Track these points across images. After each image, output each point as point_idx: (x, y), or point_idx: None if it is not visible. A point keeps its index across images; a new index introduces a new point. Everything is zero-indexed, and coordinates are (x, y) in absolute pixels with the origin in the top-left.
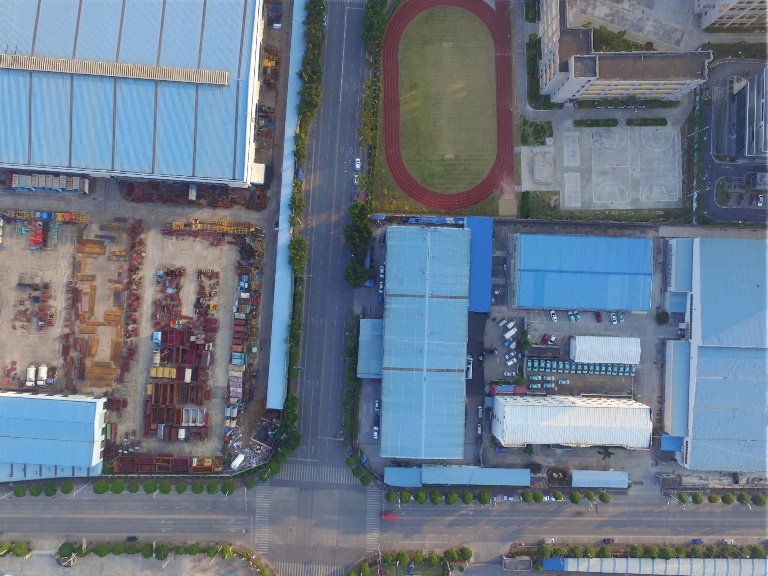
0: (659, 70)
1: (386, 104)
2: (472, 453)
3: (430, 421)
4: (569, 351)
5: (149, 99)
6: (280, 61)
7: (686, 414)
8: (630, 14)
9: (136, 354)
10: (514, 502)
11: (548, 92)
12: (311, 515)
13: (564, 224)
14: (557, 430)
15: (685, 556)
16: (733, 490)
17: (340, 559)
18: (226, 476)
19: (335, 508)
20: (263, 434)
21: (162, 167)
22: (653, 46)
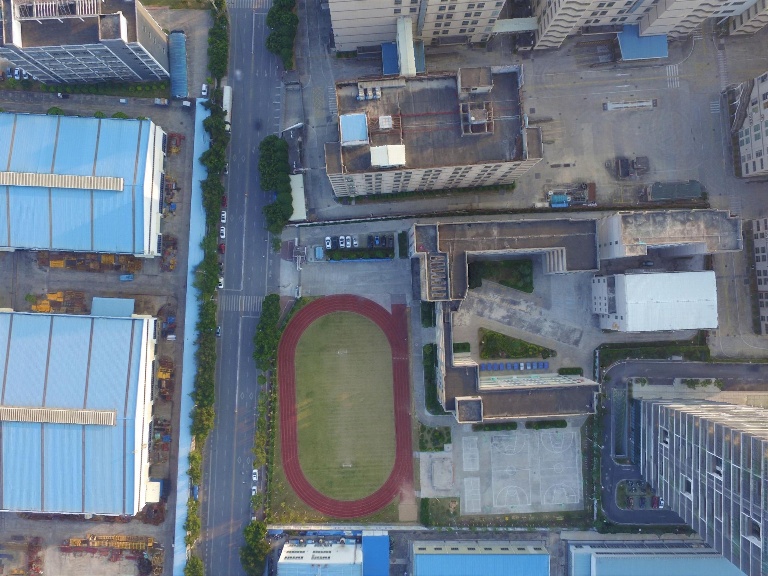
0: (547, 403)
1: (283, 413)
2: None
3: None
4: None
5: (35, 440)
6: (175, 372)
7: None
8: (527, 315)
9: None
10: None
11: None
12: None
13: None
14: None
15: None
16: None
17: None
18: None
19: None
20: None
21: (51, 505)
22: (551, 347)
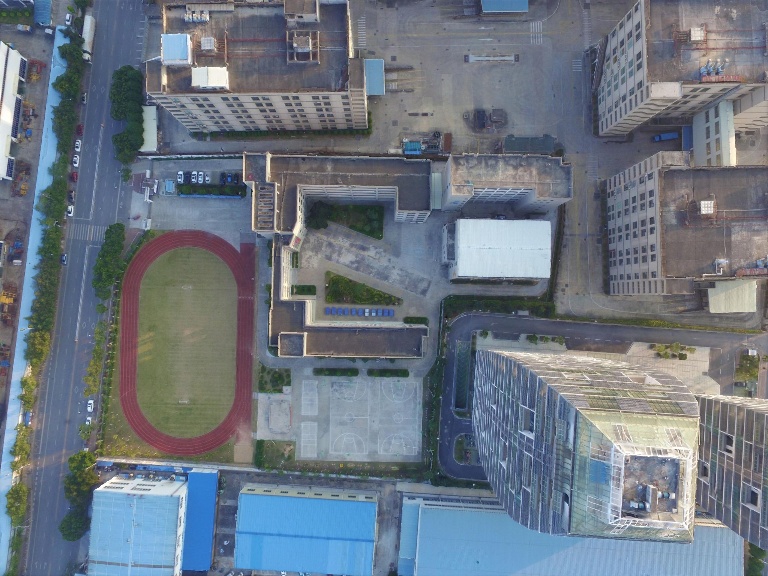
0: (375, 344)
1: (124, 345)
2: None
3: None
4: None
5: None
6: (19, 297)
7: None
8: (376, 262)
9: None
10: None
11: None
12: None
13: (298, 475)
14: None
15: None
16: None
17: None
18: None
19: None
20: None
21: None
22: (398, 295)
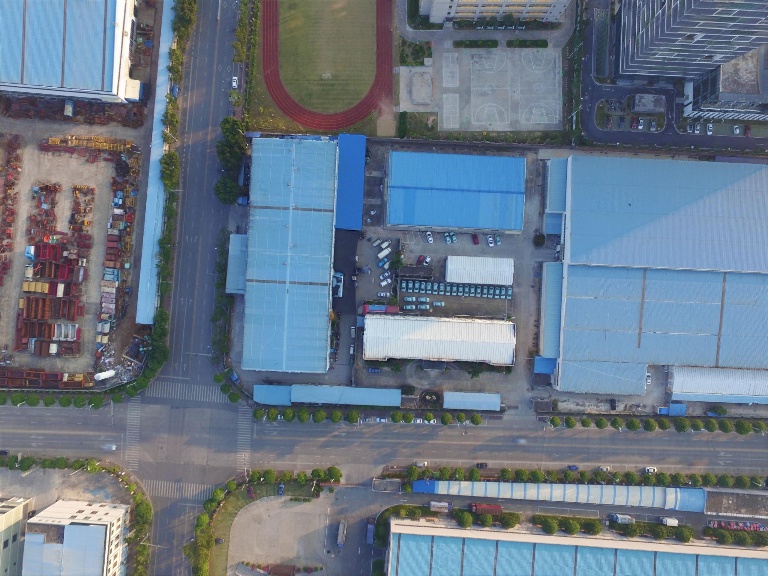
0: None
1: (265, 23)
2: (345, 374)
3: (292, 334)
4: (445, 273)
5: (18, 9)
6: None
7: (558, 335)
8: None
9: (10, 269)
10: (387, 424)
11: (426, 11)
12: (182, 433)
13: (442, 145)
14: (418, 344)
15: (559, 482)
16: (610, 416)
17: (210, 478)
18: (96, 391)
19: (206, 427)
20: (134, 350)
21: (31, 77)
22: None
